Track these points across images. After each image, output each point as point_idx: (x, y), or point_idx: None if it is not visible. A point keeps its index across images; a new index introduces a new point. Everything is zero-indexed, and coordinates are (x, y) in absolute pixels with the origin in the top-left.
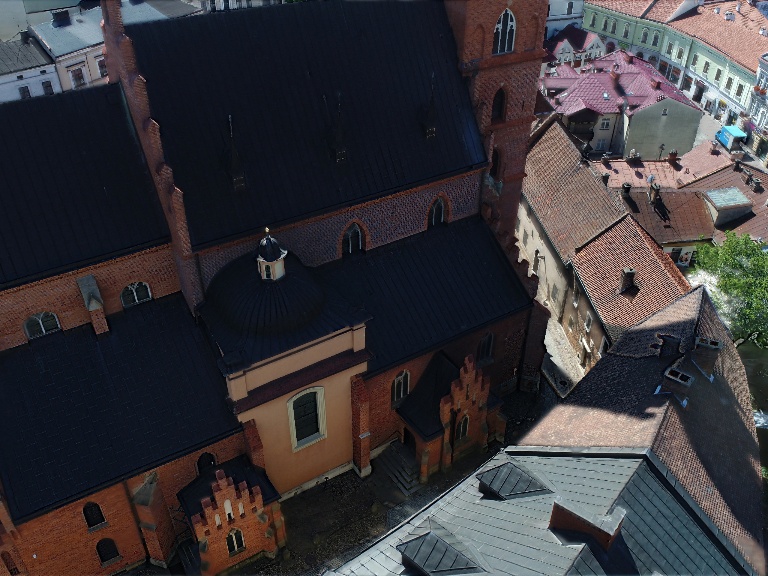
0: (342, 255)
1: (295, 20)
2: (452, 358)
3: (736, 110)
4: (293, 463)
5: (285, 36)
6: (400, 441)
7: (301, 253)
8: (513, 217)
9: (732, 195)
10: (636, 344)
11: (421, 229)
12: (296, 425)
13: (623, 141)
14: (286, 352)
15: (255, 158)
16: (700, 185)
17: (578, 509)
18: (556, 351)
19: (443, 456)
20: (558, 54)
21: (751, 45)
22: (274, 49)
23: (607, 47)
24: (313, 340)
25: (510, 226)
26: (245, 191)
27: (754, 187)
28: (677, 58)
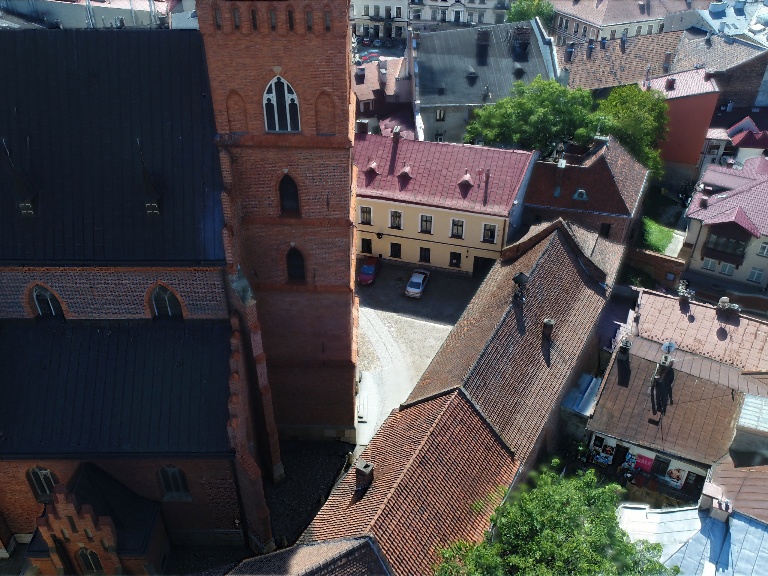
0: (42, 315)
1: (13, 49)
2: (115, 476)
3: None
4: None
5: None
6: None
7: None
8: (344, 336)
9: None
10: (249, 571)
11: (143, 315)
12: None
13: None
14: None
15: None
16: None
17: None
18: None
19: None
20: None
21: None
22: None
23: None
24: None
25: (342, 345)
26: None
27: None
28: None
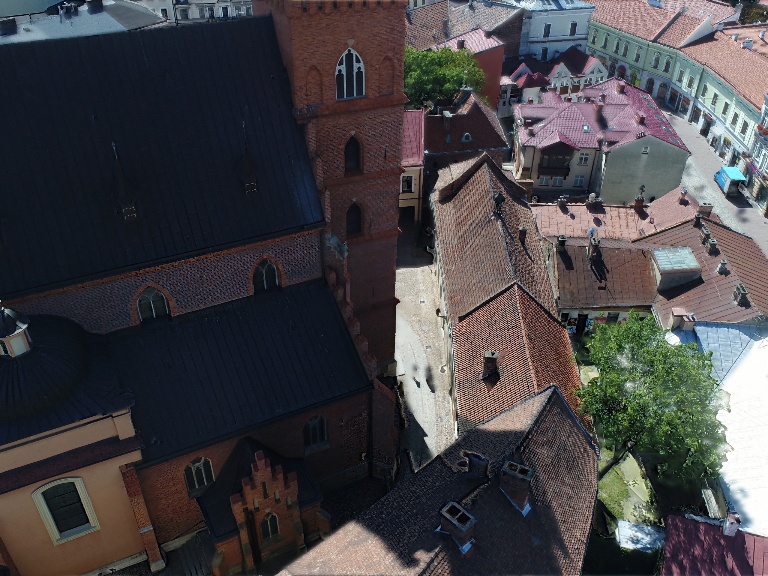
0: (143, 320)
1: (79, 57)
2: (267, 444)
3: (740, 149)
4: (59, 555)
5: (65, 75)
6: (208, 531)
7: (81, 319)
8: (390, 276)
9: (681, 256)
10: None
11: (245, 294)
12: (56, 516)
13: (600, 179)
14: (19, 441)
15: (17, 213)
16: (655, 240)
17: None
18: (434, 429)
19: (244, 557)
20: (553, 78)
21: (762, 78)
22: (49, 89)
23: (617, 71)
24: (52, 429)
25: (388, 286)
26: (1, 250)
27: (709, 249)
28: (687, 87)
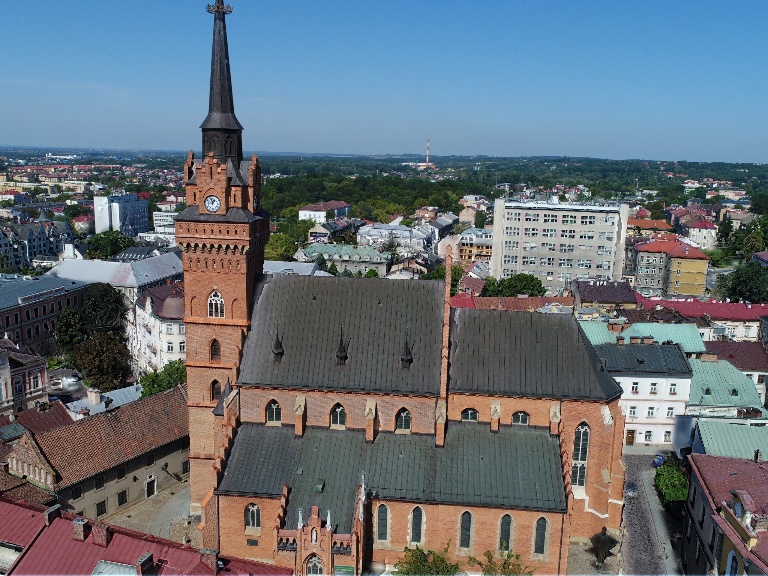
0: None
1: None
2: None
3: None
4: None
5: None
6: None
7: None
8: None
9: (8, 430)
10: None
11: None
12: None
13: None
14: None
15: None
16: None
17: None
18: None
19: None
20: None
21: None
22: None
23: None
24: None
25: None
26: None
27: None
28: None
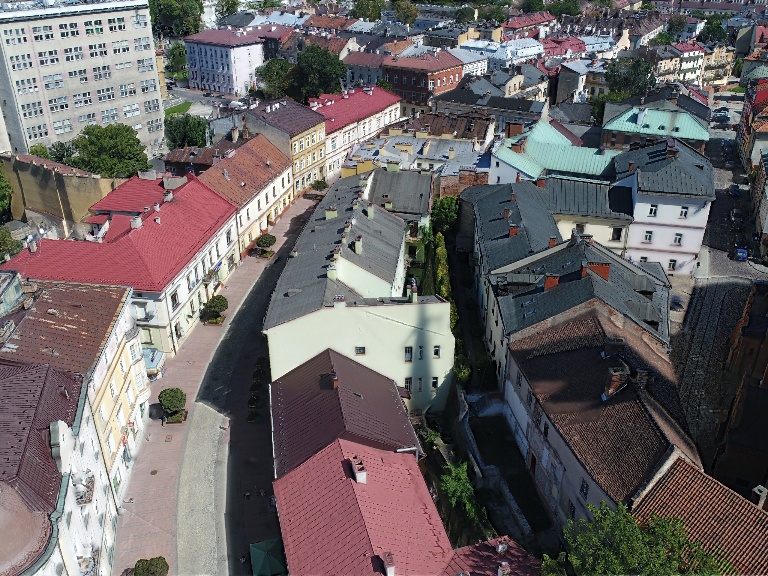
0: None
1: None
2: None
3: None
4: None
5: None
6: None
7: None
8: None
9: None
10: None
11: None
12: None
13: None
14: None
15: None
16: None
17: (600, 261)
18: None
19: None
20: None
21: None
22: None
23: None
24: None
25: None
26: None
27: None
28: None
